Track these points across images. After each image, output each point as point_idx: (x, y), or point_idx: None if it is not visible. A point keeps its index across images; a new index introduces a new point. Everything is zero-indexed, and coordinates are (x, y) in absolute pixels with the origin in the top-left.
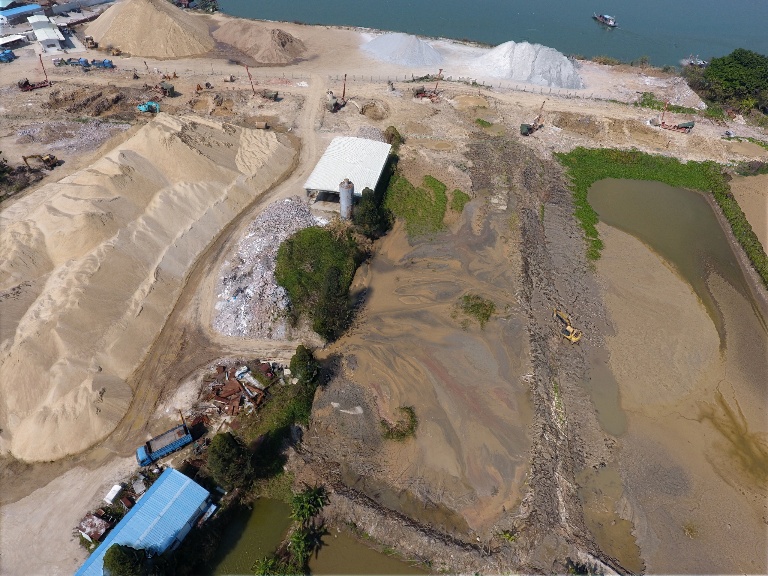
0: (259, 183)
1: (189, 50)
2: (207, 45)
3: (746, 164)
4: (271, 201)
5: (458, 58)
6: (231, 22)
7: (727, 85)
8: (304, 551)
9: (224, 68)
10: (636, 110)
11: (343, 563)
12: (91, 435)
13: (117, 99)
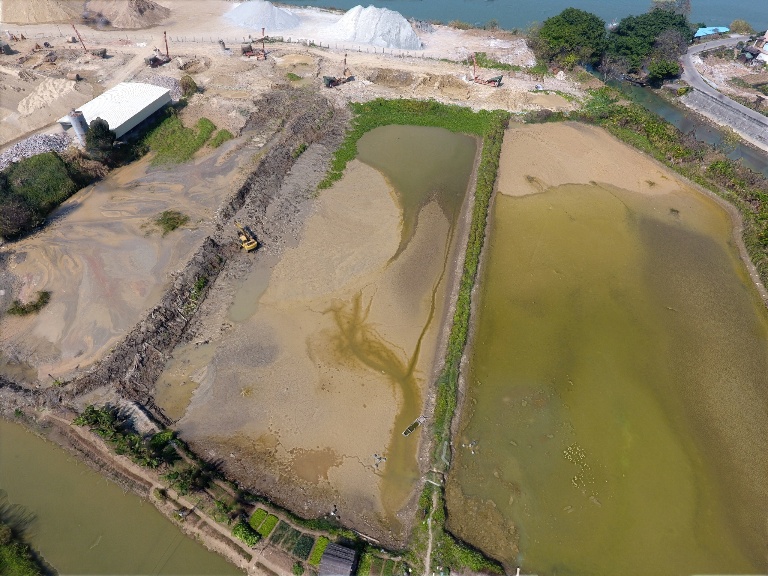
0: (34, 121)
1: (51, 16)
2: (72, 13)
3: (535, 113)
4: None
5: (315, 24)
6: None
7: (554, 43)
8: None
9: None
10: (462, 68)
11: None
12: None
13: None
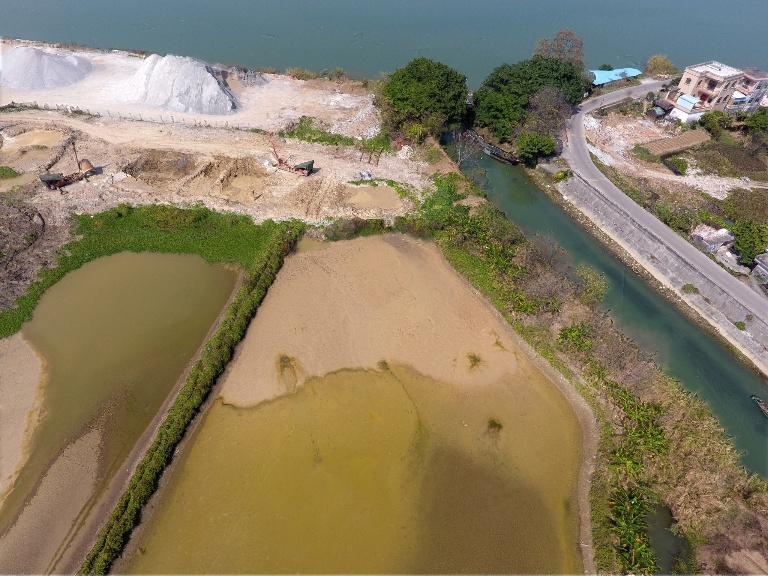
0: None
1: None
2: None
3: (342, 223)
4: None
5: (106, 76)
6: None
7: (400, 106)
8: None
9: None
10: (274, 143)
11: None
12: None
13: None
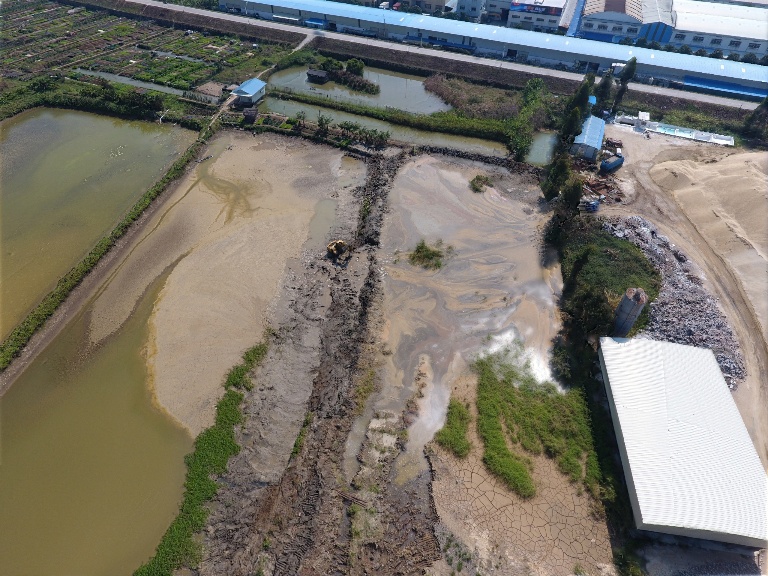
0: None
1: None
2: None
3: None
4: (751, 378)
5: None
6: None
7: None
8: None
9: None
10: None
11: None
12: None
13: None
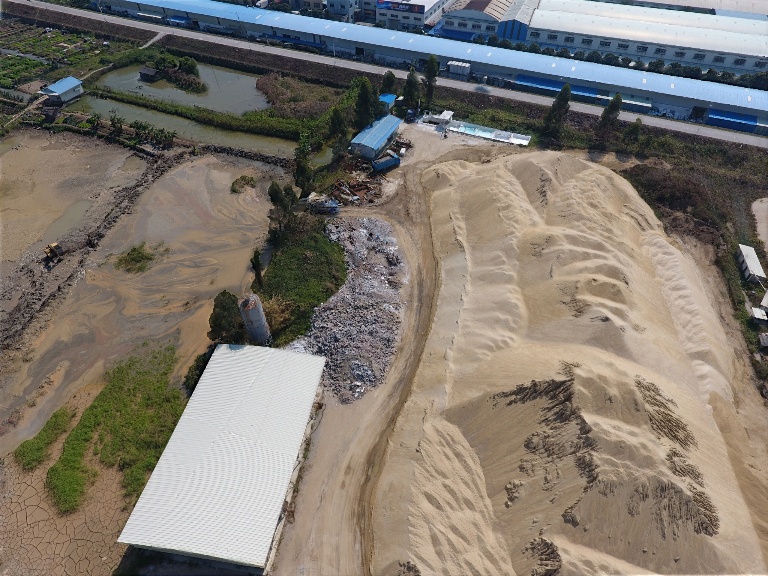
0: (414, 414)
1: None
2: None
3: None
4: (384, 386)
5: None
6: None
7: None
8: None
9: None
10: None
11: None
12: None
13: None
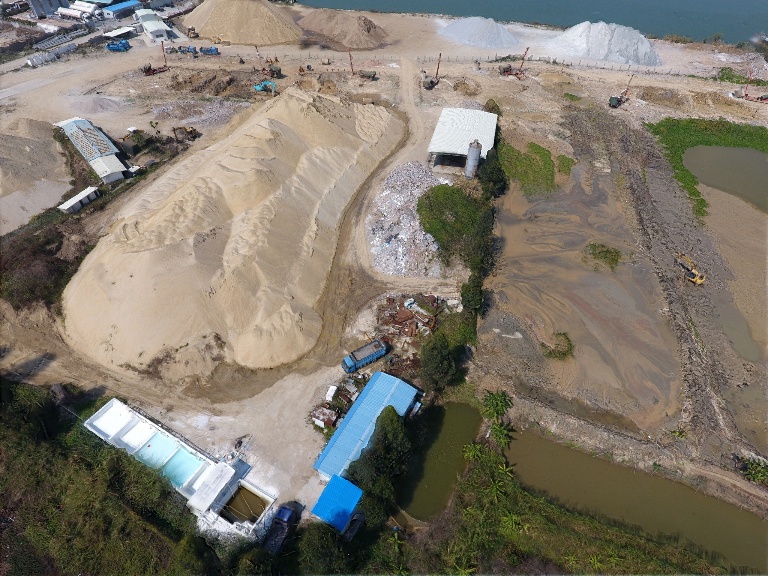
0: (381, 150)
1: (282, 37)
2: (297, 33)
3: None
4: (394, 165)
5: (533, 40)
6: (316, 11)
7: None
8: (505, 438)
9: (318, 53)
10: (716, 84)
11: (533, 453)
12: (298, 349)
13: (230, 81)
